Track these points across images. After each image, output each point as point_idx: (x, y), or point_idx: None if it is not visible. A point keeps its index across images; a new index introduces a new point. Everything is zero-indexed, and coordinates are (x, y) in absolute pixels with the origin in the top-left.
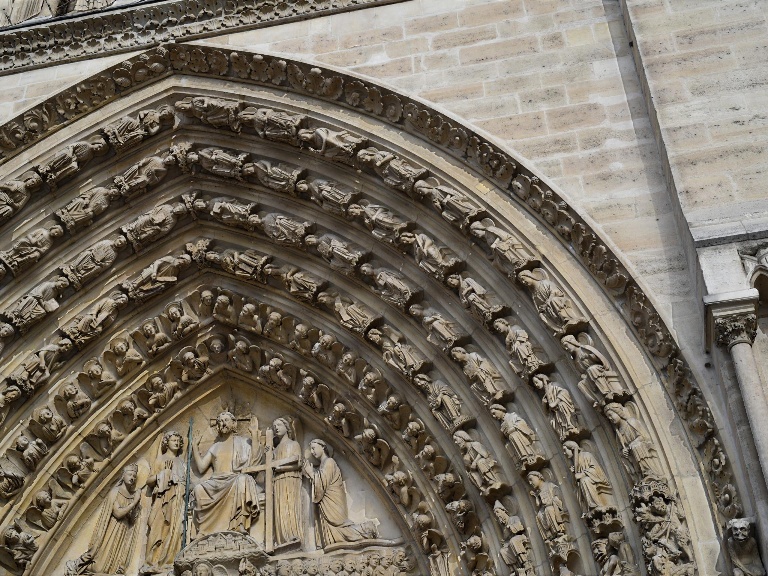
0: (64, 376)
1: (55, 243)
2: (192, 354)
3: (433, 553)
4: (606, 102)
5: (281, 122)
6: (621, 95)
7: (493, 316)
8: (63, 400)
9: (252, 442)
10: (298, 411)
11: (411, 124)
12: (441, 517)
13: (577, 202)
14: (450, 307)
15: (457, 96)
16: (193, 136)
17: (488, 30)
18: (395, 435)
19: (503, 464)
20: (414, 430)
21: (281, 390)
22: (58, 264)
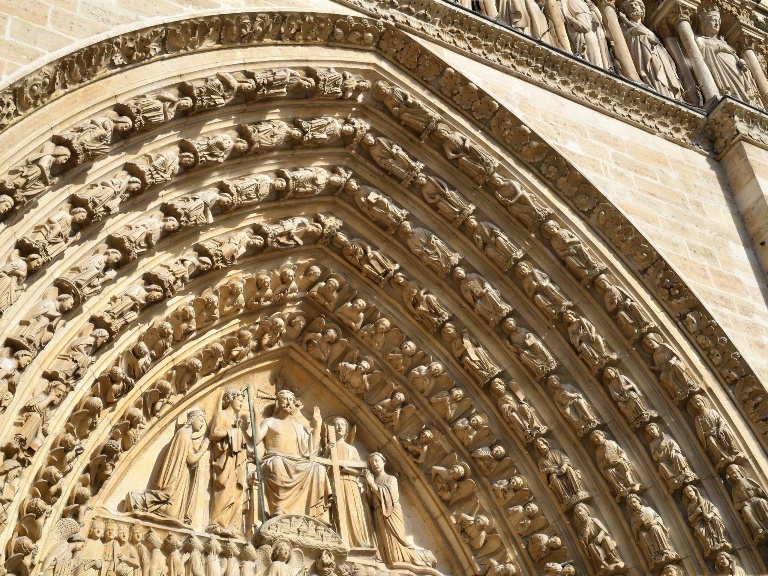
0: (182, 293)
1: None
2: None
3: None
4: (746, 281)
5: (484, 157)
6: (755, 281)
7: None
8: (180, 319)
9: (316, 432)
10: (355, 417)
11: (597, 220)
12: (525, 571)
13: (748, 357)
14: (589, 391)
15: (642, 217)
16: (372, 118)
17: (650, 170)
18: (479, 480)
19: (621, 546)
20: None
21: (352, 392)
22: (222, 177)
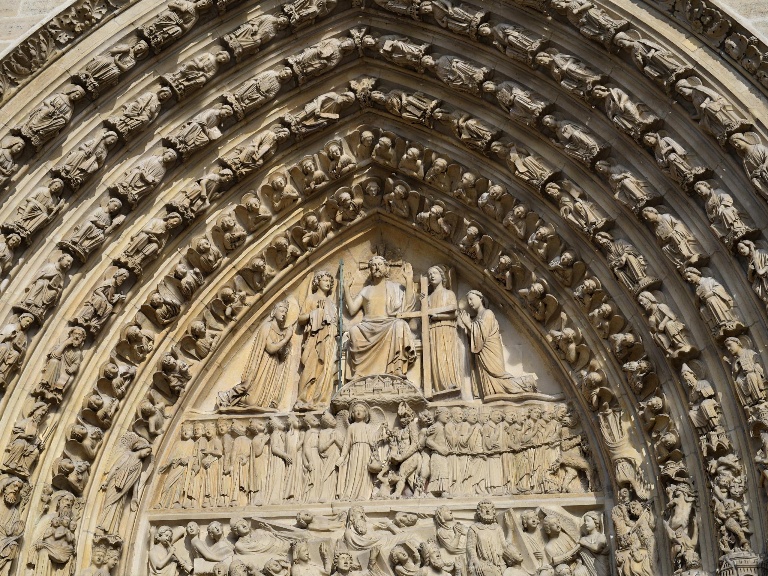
0: (221, 207)
1: (220, 69)
2: (349, 195)
3: (604, 411)
4: None
5: None
6: None
7: (695, 178)
8: (221, 231)
9: (406, 288)
10: (453, 261)
11: None
12: (613, 376)
13: None
14: (641, 166)
15: None
16: None
17: None
18: (564, 292)
19: (692, 328)
20: (590, 288)
21: (438, 238)
22: (221, 91)
